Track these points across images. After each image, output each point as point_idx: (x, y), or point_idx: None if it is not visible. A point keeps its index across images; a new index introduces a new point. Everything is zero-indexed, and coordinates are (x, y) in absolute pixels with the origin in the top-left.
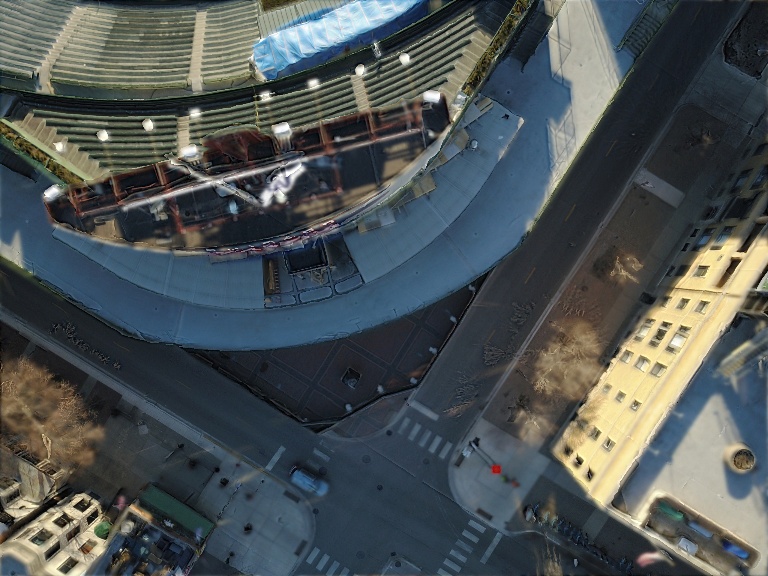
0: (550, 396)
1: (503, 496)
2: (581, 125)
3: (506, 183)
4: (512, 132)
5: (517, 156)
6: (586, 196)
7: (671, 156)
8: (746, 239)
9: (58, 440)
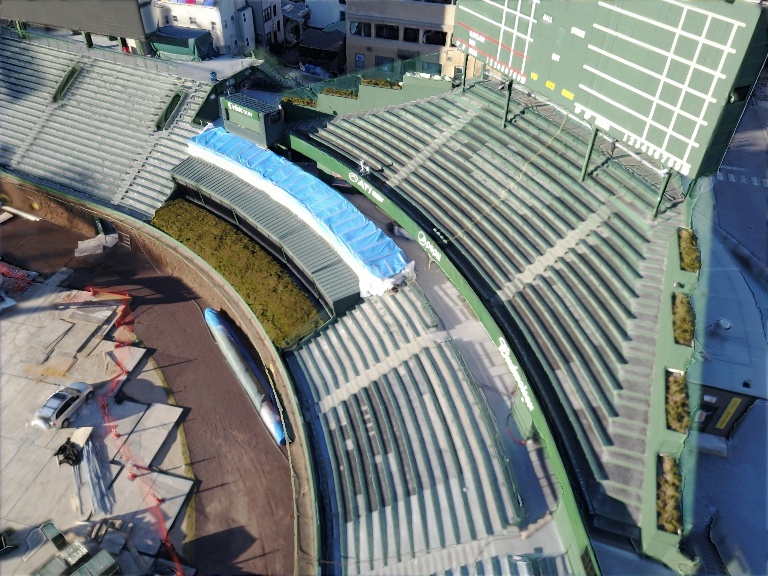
0: None
1: None
2: None
3: None
4: None
5: None
6: None
7: None
8: (435, 45)
9: None
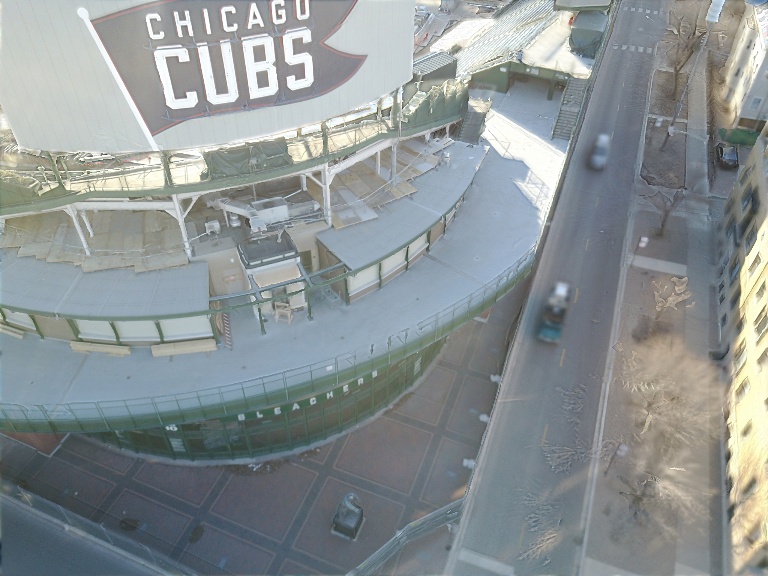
0: (674, 500)
1: None
2: (546, 178)
3: (492, 220)
4: (481, 154)
5: (494, 202)
6: (585, 280)
7: (649, 242)
8: None
9: None
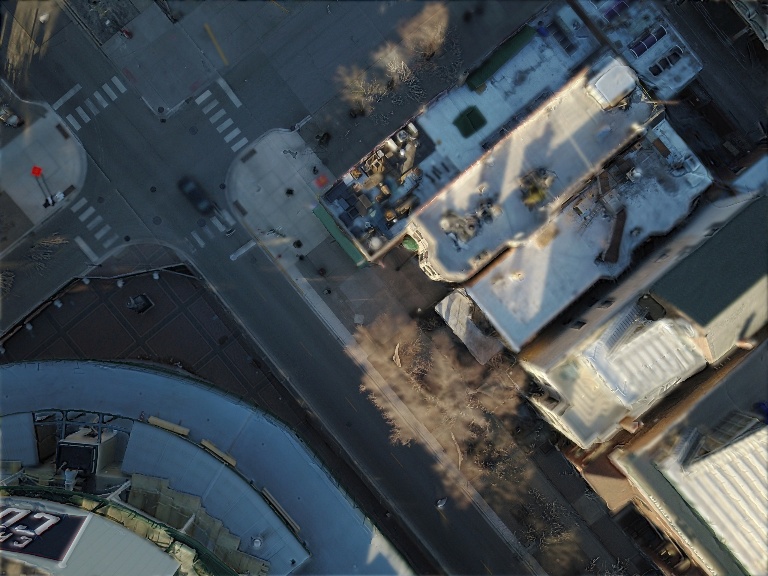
0: None
1: (39, 143)
2: None
3: None
4: None
5: None
6: None
7: None
8: None
9: (442, 337)
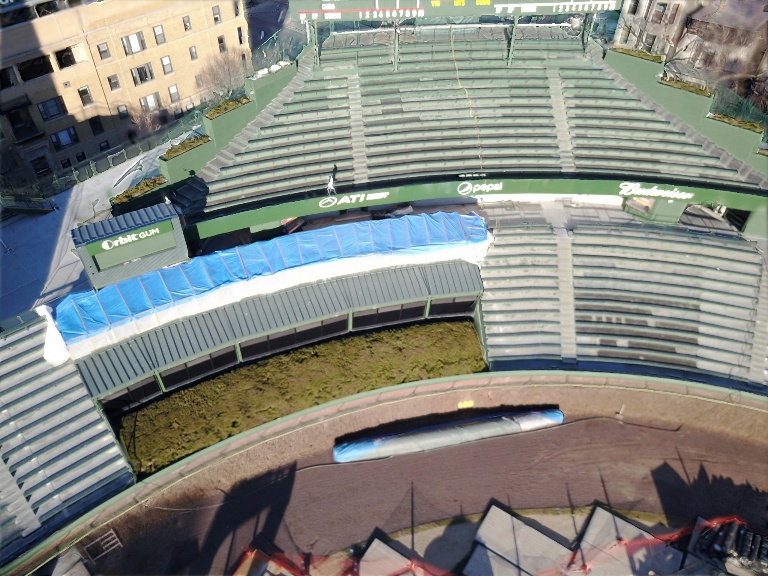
0: None
1: None
2: None
3: None
4: None
5: None
6: None
7: None
8: (40, 77)
9: None
